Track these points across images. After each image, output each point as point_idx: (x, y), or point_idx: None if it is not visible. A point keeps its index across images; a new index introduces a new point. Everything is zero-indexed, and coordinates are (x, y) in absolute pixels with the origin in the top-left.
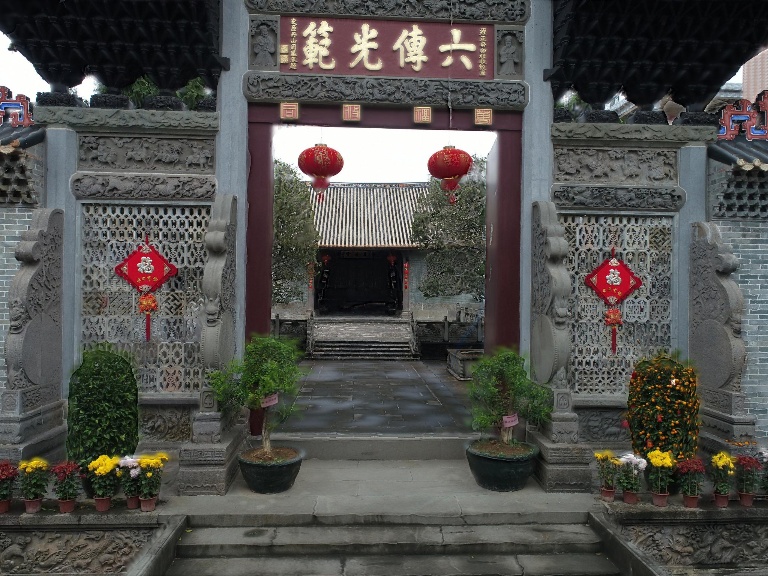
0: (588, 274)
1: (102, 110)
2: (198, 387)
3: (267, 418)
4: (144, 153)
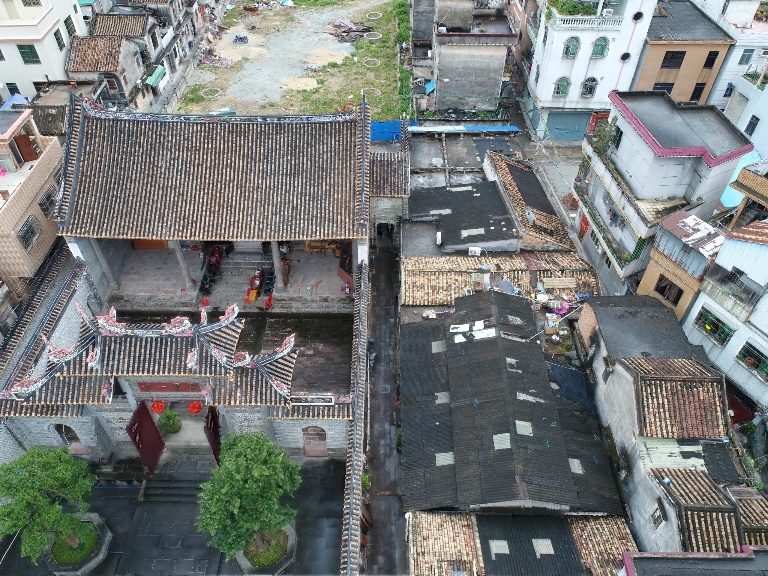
0: (129, 420)
1: None
2: None
3: None
4: None
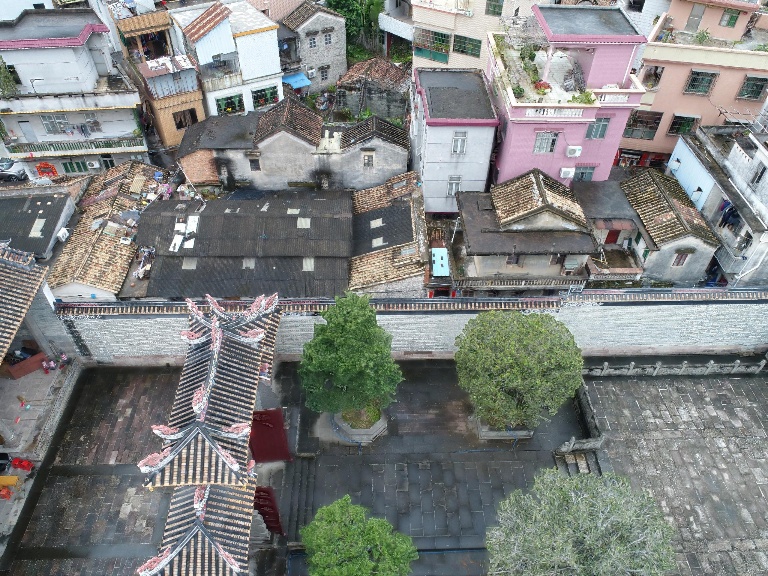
0: None
1: None
2: None
3: None
4: None
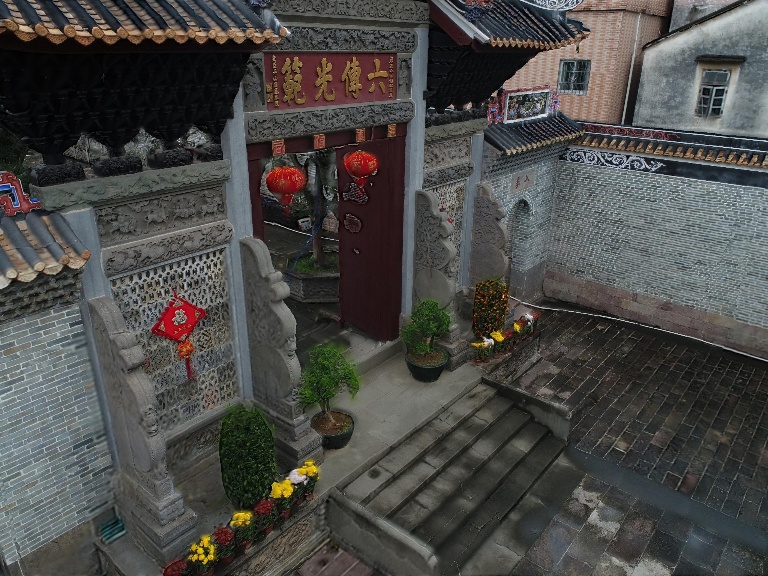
0: None
1: (123, 180)
2: (230, 395)
3: (328, 401)
4: (164, 213)
